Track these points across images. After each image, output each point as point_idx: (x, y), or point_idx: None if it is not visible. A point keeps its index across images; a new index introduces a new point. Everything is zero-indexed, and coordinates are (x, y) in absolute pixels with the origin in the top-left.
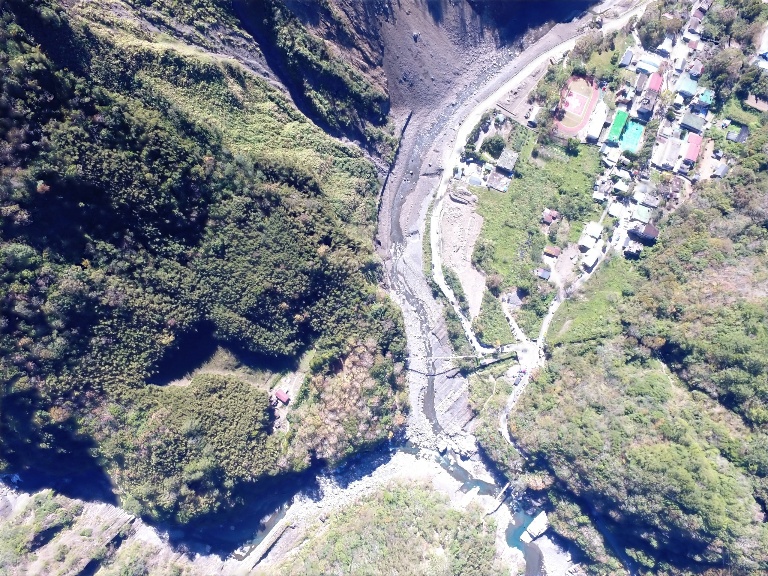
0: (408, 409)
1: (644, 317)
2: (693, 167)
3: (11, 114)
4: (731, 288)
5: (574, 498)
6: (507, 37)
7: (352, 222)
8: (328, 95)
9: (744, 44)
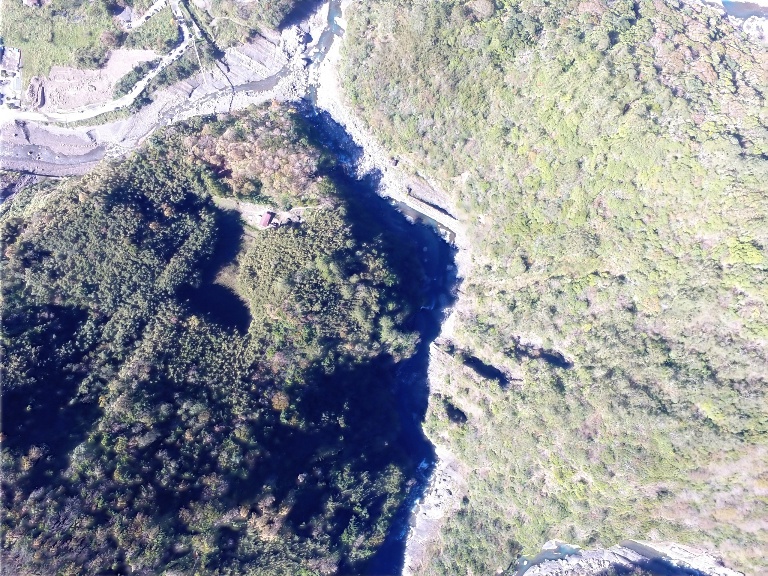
0: (269, 103)
1: None
2: None
3: None
4: None
5: None
6: None
7: None
8: None
9: None
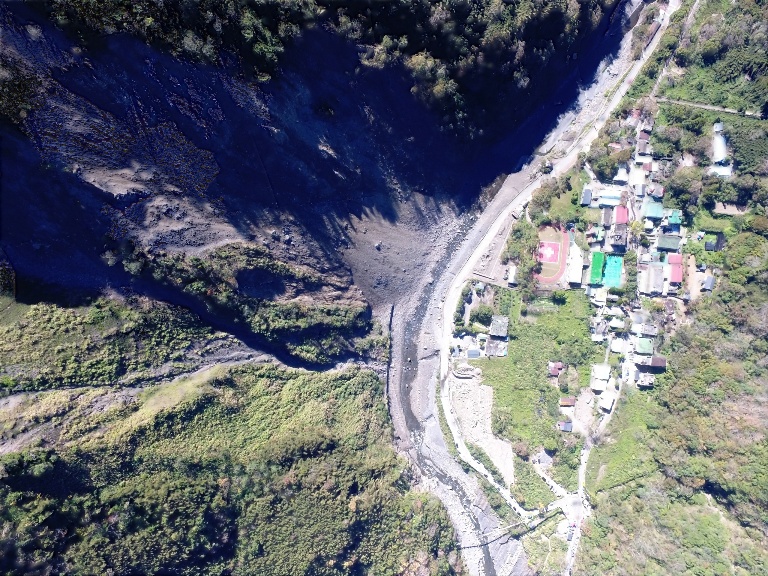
0: None
1: (676, 455)
2: (681, 287)
3: (33, 567)
4: (755, 424)
5: None
6: (463, 202)
7: (369, 444)
8: (312, 341)
9: (697, 156)
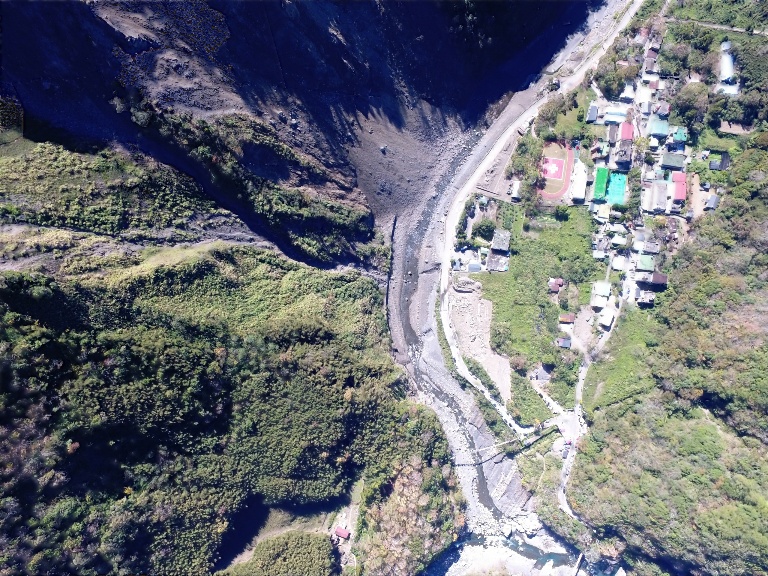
0: (465, 504)
1: (675, 368)
2: (684, 205)
3: (27, 394)
4: (756, 330)
5: (650, 558)
6: (470, 118)
7: (367, 346)
8: (314, 235)
9: (704, 74)
